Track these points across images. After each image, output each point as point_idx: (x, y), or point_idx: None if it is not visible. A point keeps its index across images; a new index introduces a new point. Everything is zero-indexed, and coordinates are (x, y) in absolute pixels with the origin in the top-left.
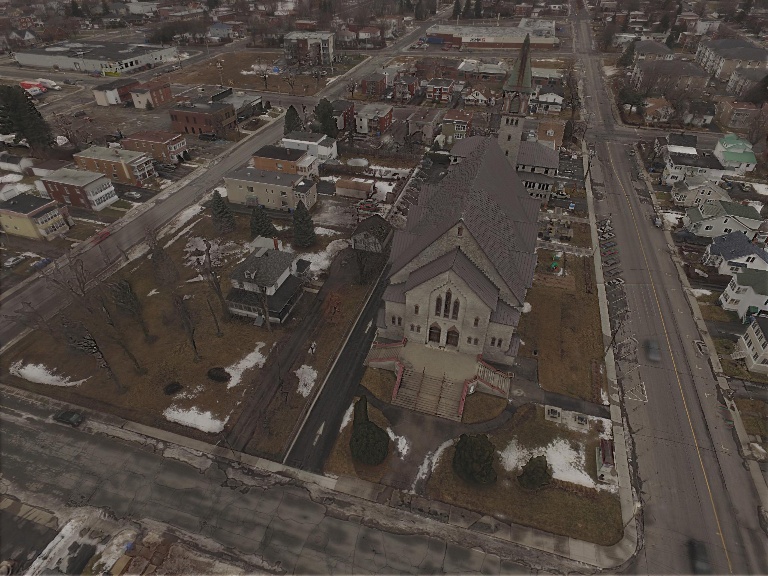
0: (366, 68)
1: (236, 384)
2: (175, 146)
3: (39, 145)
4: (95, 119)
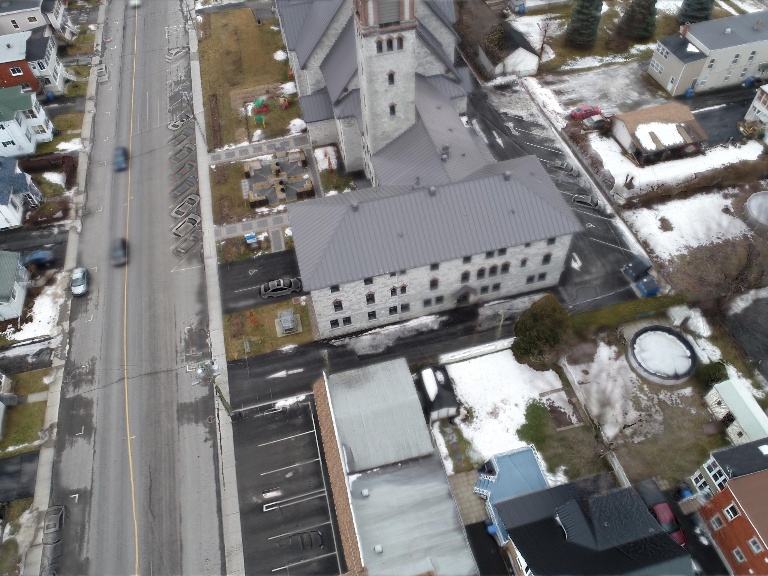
0: None
1: None
2: None
3: None
4: None
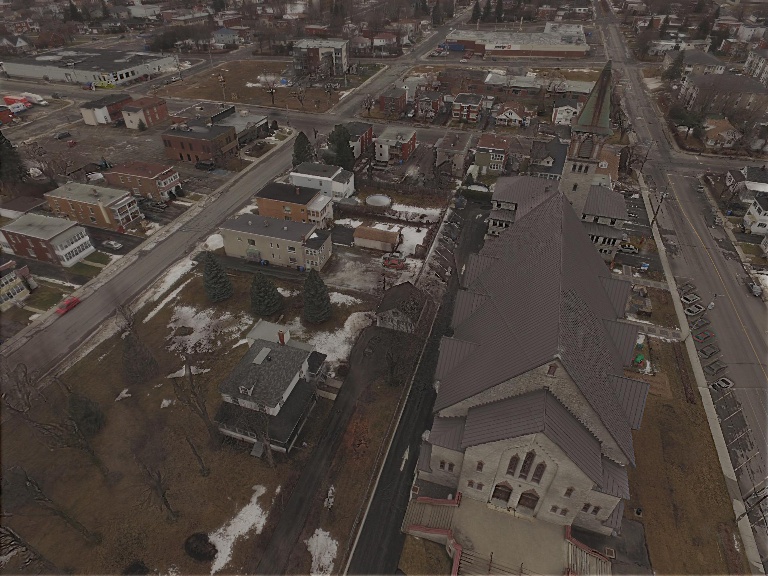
0: (382, 79)
1: (223, 566)
2: (165, 181)
3: (8, 179)
4: (80, 142)
